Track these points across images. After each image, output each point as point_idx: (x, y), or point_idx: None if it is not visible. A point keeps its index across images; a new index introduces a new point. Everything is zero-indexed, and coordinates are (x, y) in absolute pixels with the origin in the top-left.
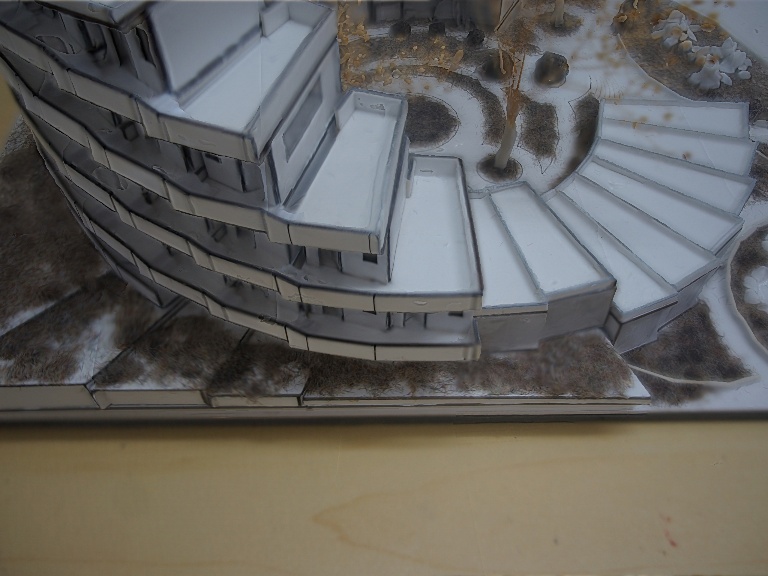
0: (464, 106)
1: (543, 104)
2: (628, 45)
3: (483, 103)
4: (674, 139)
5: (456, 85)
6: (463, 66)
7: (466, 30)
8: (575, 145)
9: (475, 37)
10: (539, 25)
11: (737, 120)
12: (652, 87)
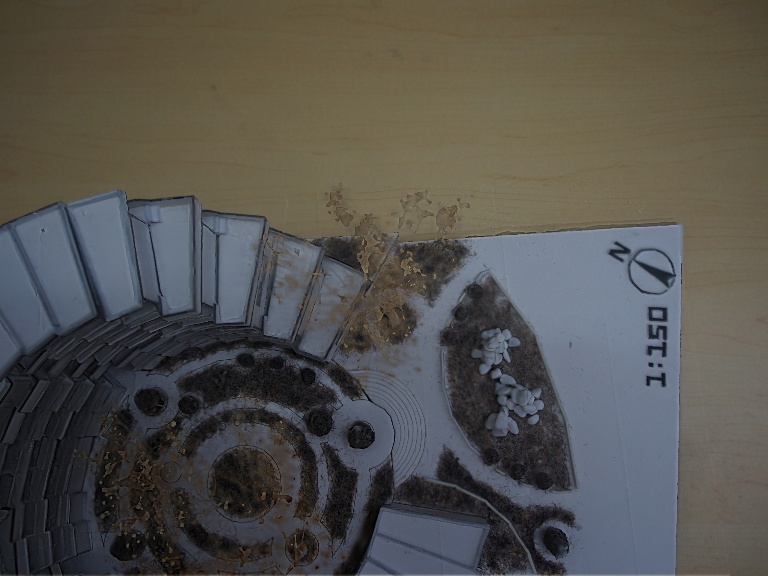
0: (287, 466)
1: (349, 470)
2: (449, 363)
3: (303, 463)
4: (424, 558)
5: (285, 438)
6: (294, 410)
7: (303, 358)
8: (362, 528)
9: (306, 382)
10: (378, 324)
11: (477, 542)
12: (453, 426)
